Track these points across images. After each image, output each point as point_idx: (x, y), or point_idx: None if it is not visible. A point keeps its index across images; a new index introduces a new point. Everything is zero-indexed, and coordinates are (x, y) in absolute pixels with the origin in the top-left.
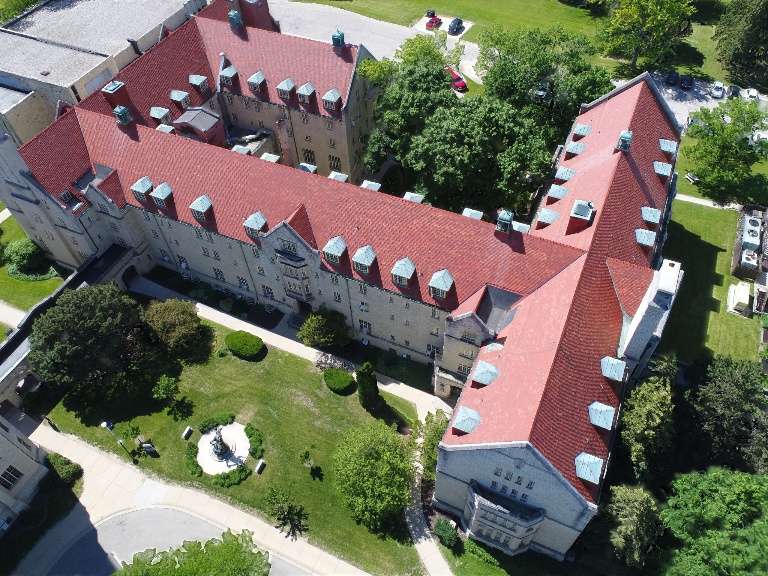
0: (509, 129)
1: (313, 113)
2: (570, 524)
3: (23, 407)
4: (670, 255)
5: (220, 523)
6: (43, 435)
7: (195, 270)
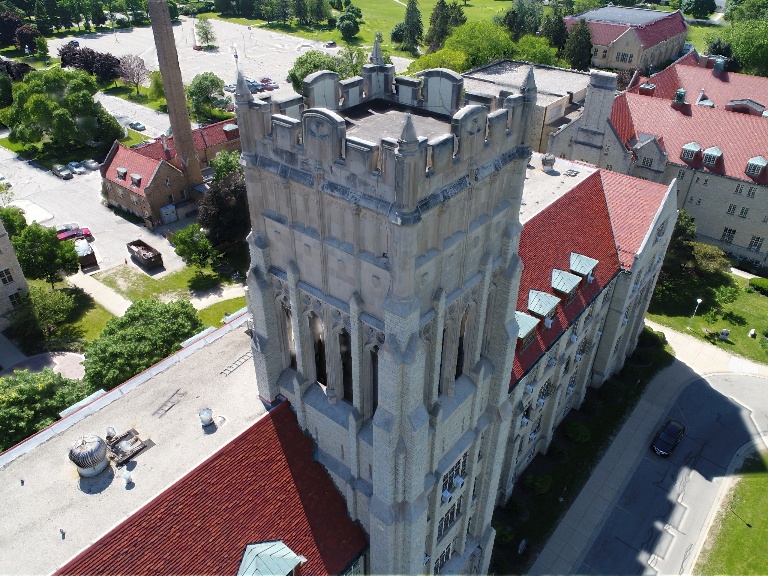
0: None
1: None
2: None
3: None
4: None
5: None
6: None
7: (697, 232)
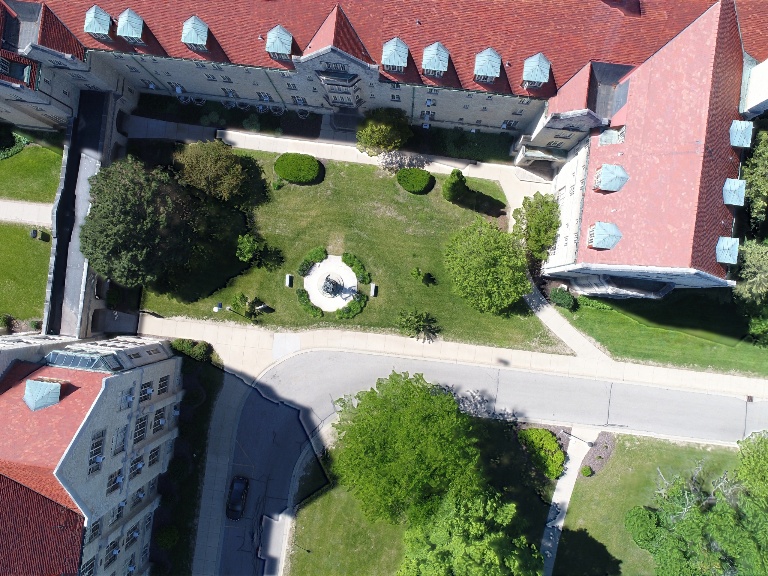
0: None
1: None
2: None
3: (111, 307)
4: None
5: (361, 349)
6: (150, 325)
7: (195, 92)
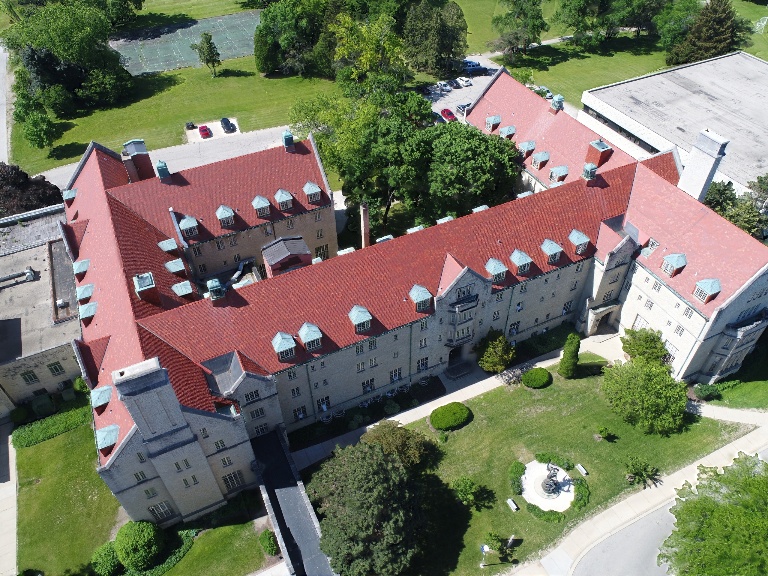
0: (480, 134)
1: (300, 213)
2: None
3: None
4: None
5: (619, 525)
6: None
7: (338, 403)
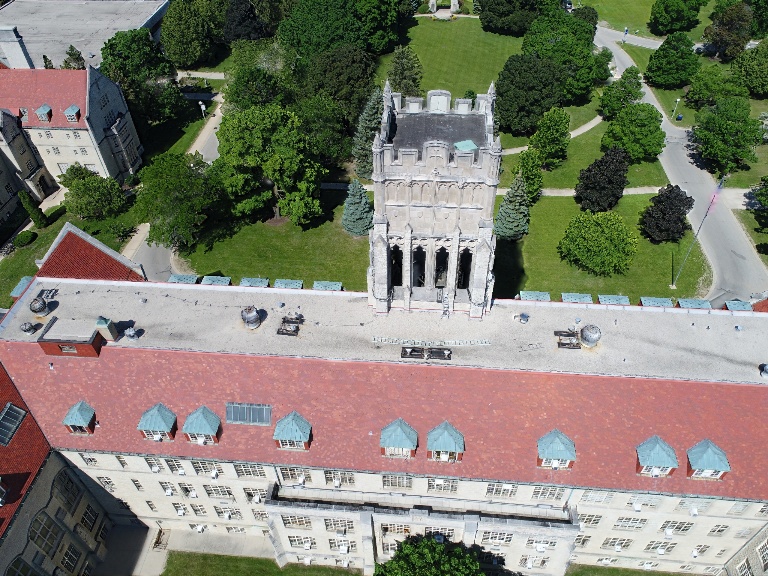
0: None
1: None
2: (125, 110)
3: None
4: None
5: None
6: None
7: None
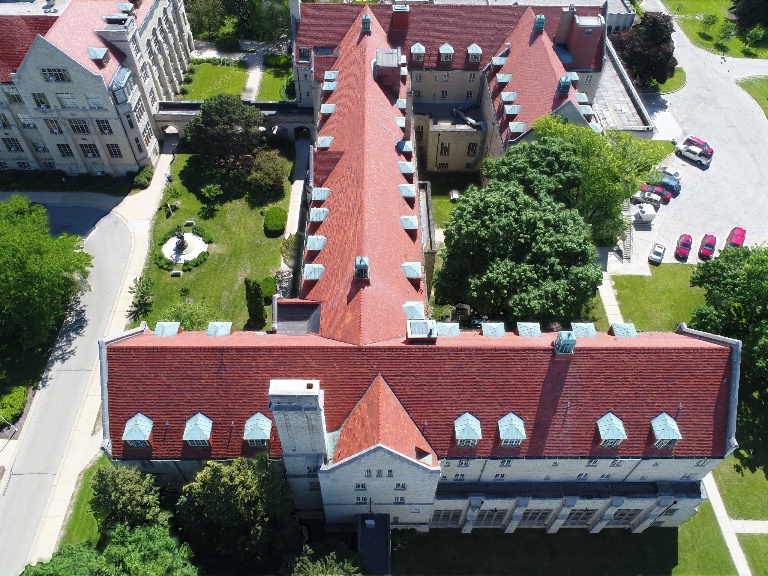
0: (539, 250)
1: (500, 131)
2: None
3: (180, 140)
4: (606, 555)
5: (128, 270)
6: (166, 159)
7: None
